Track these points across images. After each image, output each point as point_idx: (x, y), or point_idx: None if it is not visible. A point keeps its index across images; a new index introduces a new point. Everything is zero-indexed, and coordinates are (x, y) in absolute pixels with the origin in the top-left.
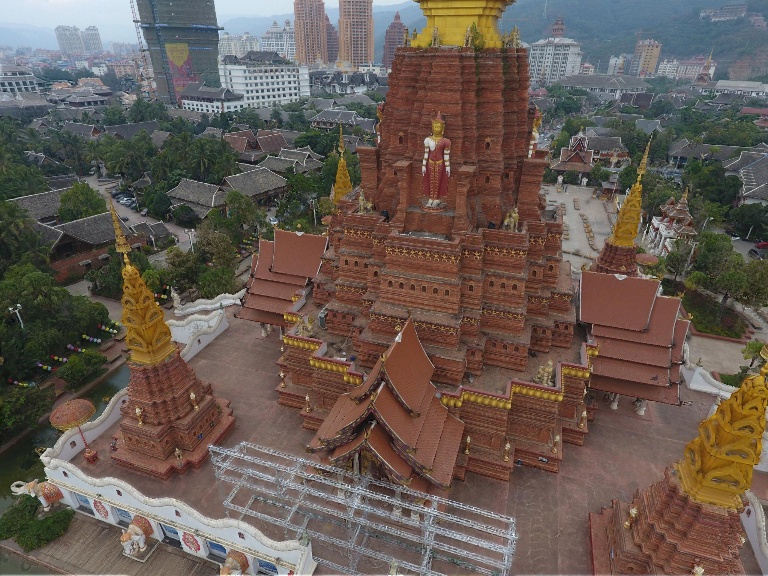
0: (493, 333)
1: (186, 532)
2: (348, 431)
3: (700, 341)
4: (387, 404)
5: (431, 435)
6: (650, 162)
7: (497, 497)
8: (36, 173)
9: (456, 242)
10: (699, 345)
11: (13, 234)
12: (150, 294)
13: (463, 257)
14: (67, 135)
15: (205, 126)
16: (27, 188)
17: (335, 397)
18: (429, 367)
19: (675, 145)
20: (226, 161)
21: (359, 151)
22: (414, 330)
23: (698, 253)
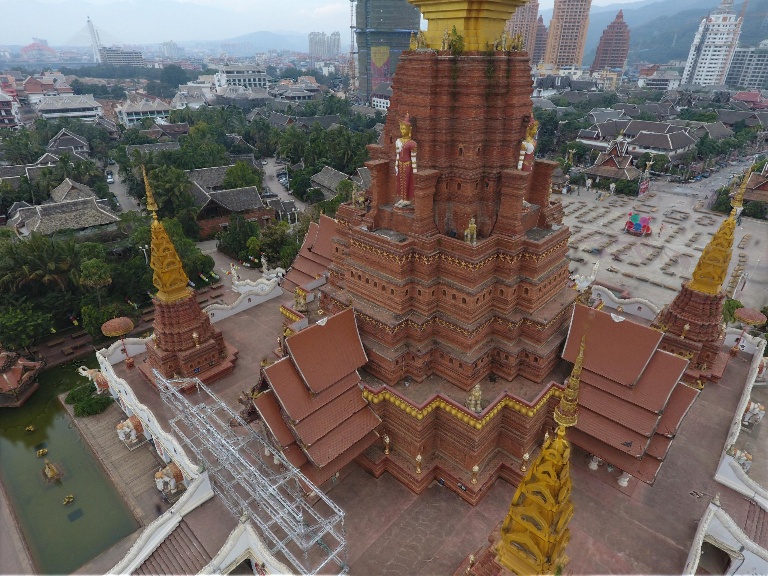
0: (444, 344)
1: (154, 437)
2: (256, 390)
3: None
4: (284, 375)
5: (330, 418)
6: None
7: (397, 504)
8: (223, 151)
9: (403, 243)
10: None
11: (176, 194)
12: (170, 246)
13: (414, 260)
14: (262, 123)
15: (376, 122)
16: (212, 162)
17: None
18: (360, 358)
19: None
20: (364, 154)
21: (369, 148)
22: (353, 320)
23: None
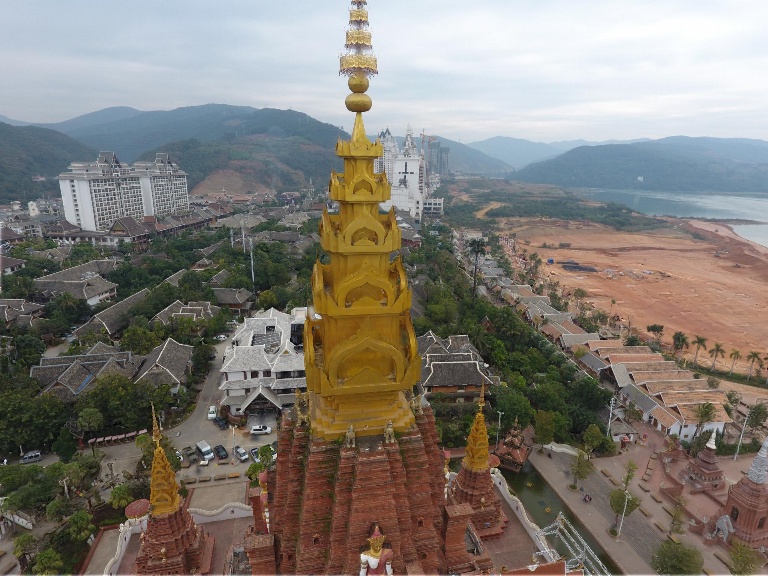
0: None
1: None
2: None
3: None
4: None
5: None
6: None
7: None
8: None
9: None
10: None
11: None
12: None
13: None
14: None
15: None
16: None
17: None
18: None
19: None
20: None
21: None
22: None
23: (40, 492)
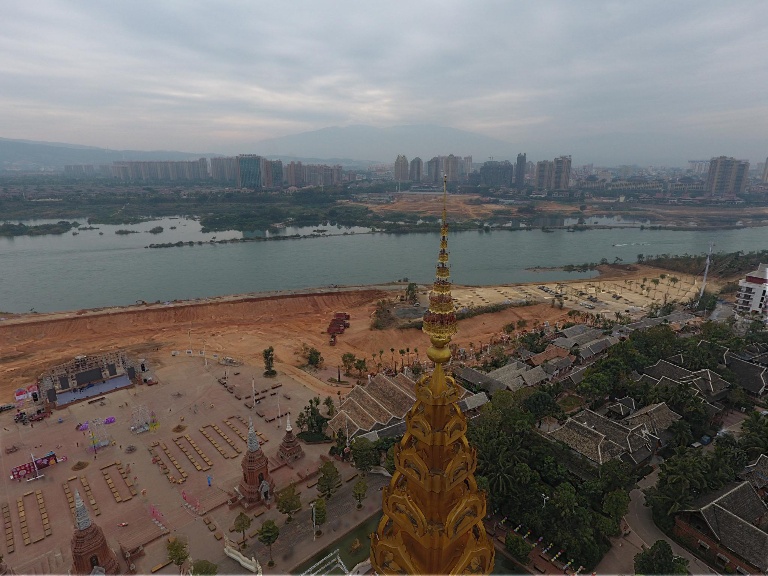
0: None
1: None
2: None
3: None
4: None
5: None
6: None
7: None
8: None
9: None
10: None
11: None
12: None
13: None
14: None
15: None
16: None
17: None
18: None
19: None
20: None
21: None
22: None
23: None
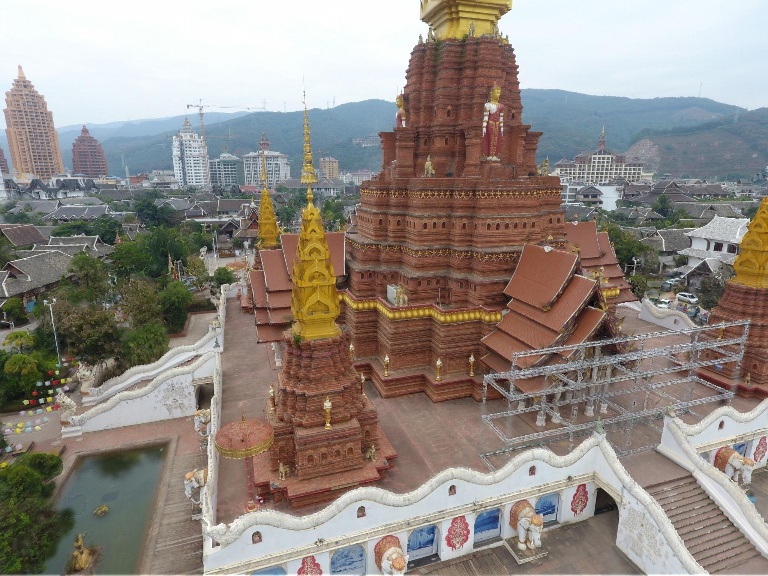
0: None
1: (458, 517)
2: (571, 324)
3: None
4: None
5: None
6: None
7: None
8: None
9: None
10: None
11: None
12: None
13: None
14: None
15: None
16: None
17: (463, 353)
18: None
19: None
20: None
21: (400, 130)
22: None
23: None
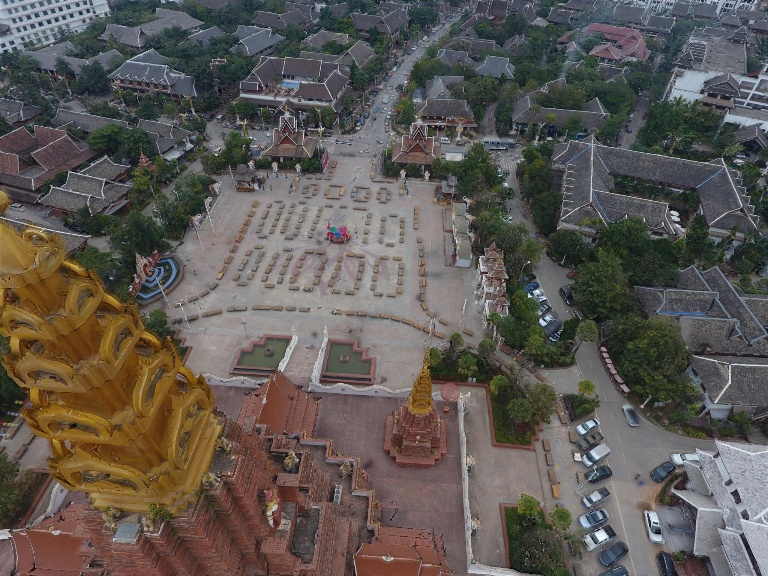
0: None
1: None
2: None
3: (498, 454)
4: None
5: None
6: (495, 126)
7: None
8: None
9: None
10: (496, 461)
11: None
12: None
13: None
14: None
15: None
16: None
17: None
18: None
19: (519, 104)
20: None
21: None
22: None
23: (508, 330)
